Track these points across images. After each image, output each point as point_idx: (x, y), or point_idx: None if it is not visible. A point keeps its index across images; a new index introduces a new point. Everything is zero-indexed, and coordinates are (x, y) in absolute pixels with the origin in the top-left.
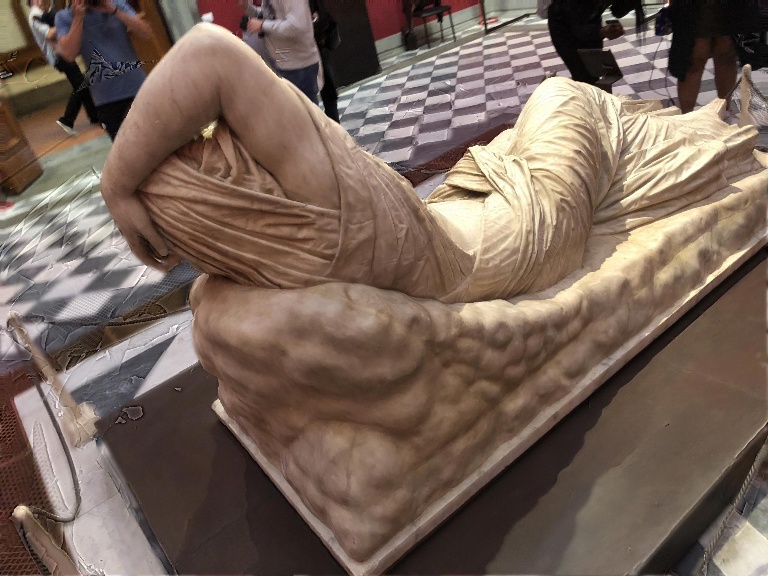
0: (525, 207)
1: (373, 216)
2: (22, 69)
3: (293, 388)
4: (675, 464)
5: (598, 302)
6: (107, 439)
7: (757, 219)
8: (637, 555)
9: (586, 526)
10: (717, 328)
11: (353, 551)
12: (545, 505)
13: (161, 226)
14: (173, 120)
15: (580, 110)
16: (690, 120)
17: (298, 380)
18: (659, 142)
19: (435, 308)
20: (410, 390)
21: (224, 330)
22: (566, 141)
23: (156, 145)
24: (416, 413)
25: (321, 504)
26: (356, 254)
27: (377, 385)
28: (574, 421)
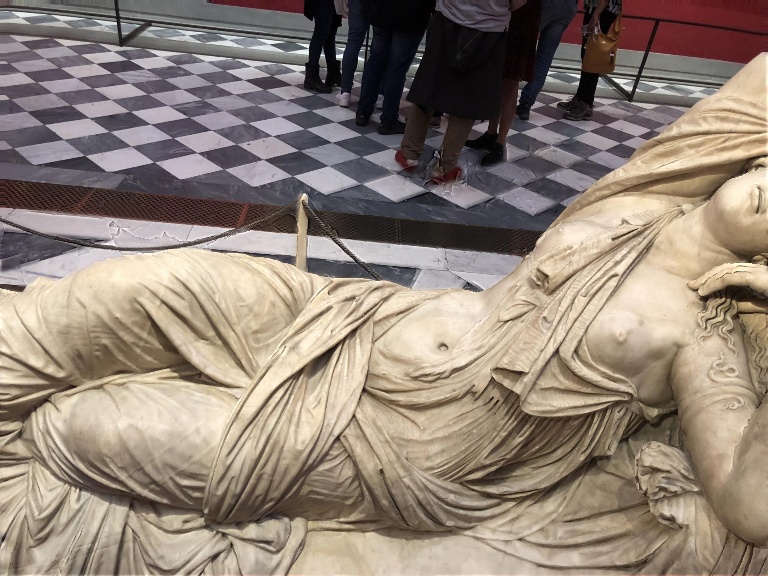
0: None
1: None
2: None
3: None
4: None
5: None
6: None
7: None
8: None
9: None
10: None
11: None
12: None
13: None
14: None
15: None
16: None
17: None
18: None
19: None
20: None
21: None
22: None
23: None
24: None
25: None
26: None
27: None
28: None
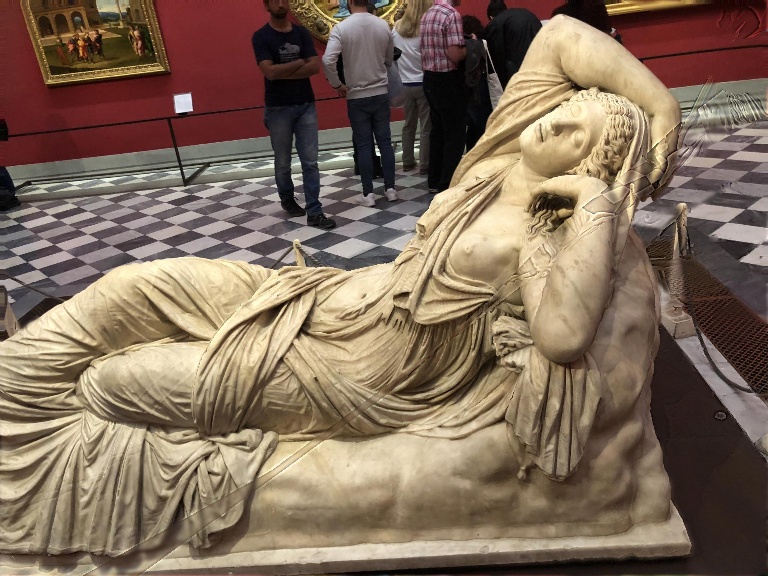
0: None
1: None
2: (762, 13)
3: None
4: None
5: None
6: None
7: None
8: None
9: None
10: None
11: None
12: None
13: None
14: None
15: None
16: None
17: None
18: None
19: None
20: None
21: None
22: None
23: None
24: None
25: None
26: None
27: None
28: None
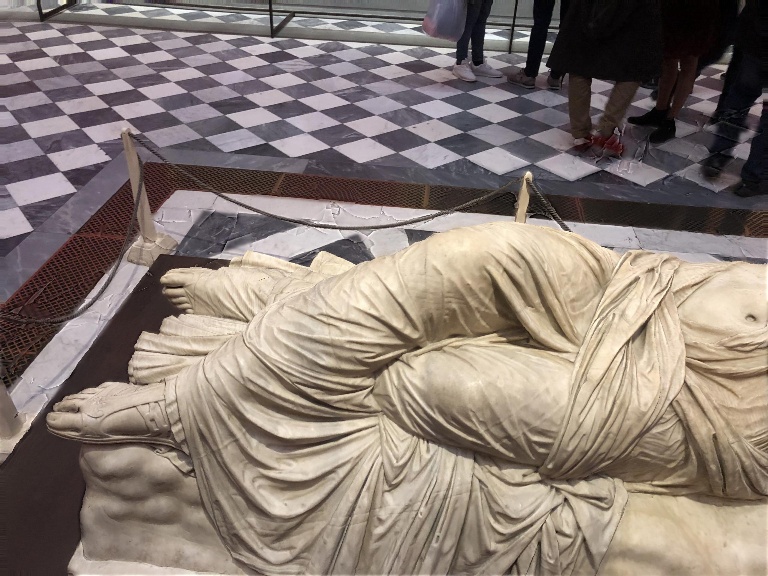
0: None
1: None
2: None
3: None
4: None
5: None
6: None
7: None
8: None
9: None
10: None
11: None
12: None
13: None
14: None
15: None
16: (268, 275)
17: None
18: None
19: None
20: None
21: None
22: None
23: None
24: None
25: None
26: None
27: None
28: None
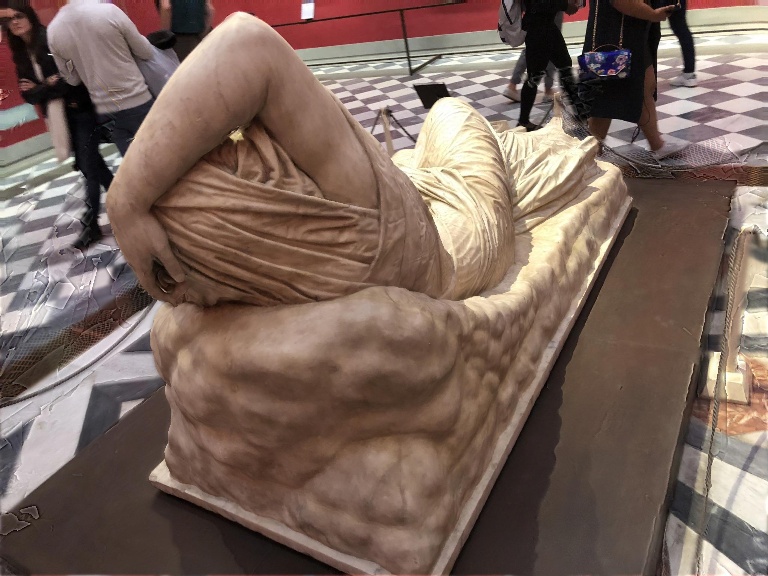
0: (473, 209)
1: (404, 214)
2: None
3: (333, 410)
4: (643, 418)
5: (541, 290)
6: (6, 554)
7: (611, 213)
8: (655, 500)
9: (602, 488)
10: (616, 304)
11: (415, 572)
12: (557, 481)
13: (181, 246)
14: (217, 117)
15: (481, 124)
16: (546, 134)
17: (350, 396)
18: (531, 153)
19: (452, 304)
20: (448, 388)
21: (259, 357)
22: (483, 150)
23: (192, 148)
24: (454, 411)
25: (366, 534)
26: (391, 255)
27: (428, 386)
28: (543, 403)
